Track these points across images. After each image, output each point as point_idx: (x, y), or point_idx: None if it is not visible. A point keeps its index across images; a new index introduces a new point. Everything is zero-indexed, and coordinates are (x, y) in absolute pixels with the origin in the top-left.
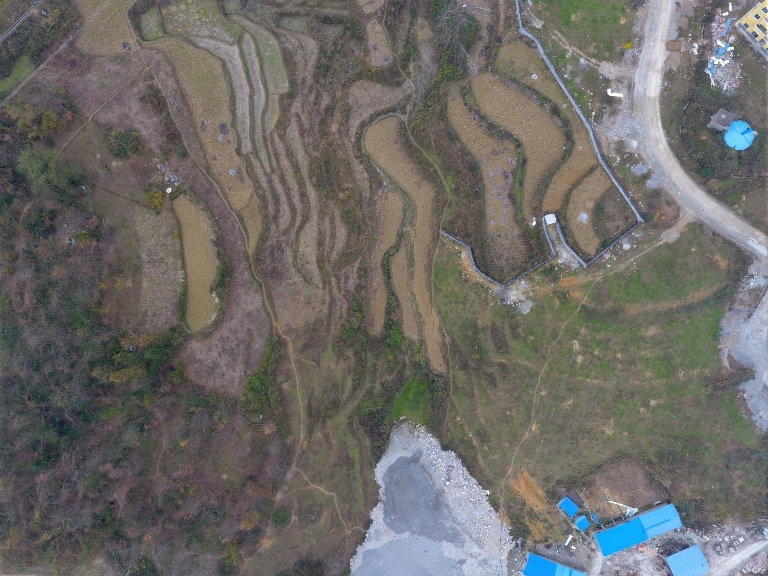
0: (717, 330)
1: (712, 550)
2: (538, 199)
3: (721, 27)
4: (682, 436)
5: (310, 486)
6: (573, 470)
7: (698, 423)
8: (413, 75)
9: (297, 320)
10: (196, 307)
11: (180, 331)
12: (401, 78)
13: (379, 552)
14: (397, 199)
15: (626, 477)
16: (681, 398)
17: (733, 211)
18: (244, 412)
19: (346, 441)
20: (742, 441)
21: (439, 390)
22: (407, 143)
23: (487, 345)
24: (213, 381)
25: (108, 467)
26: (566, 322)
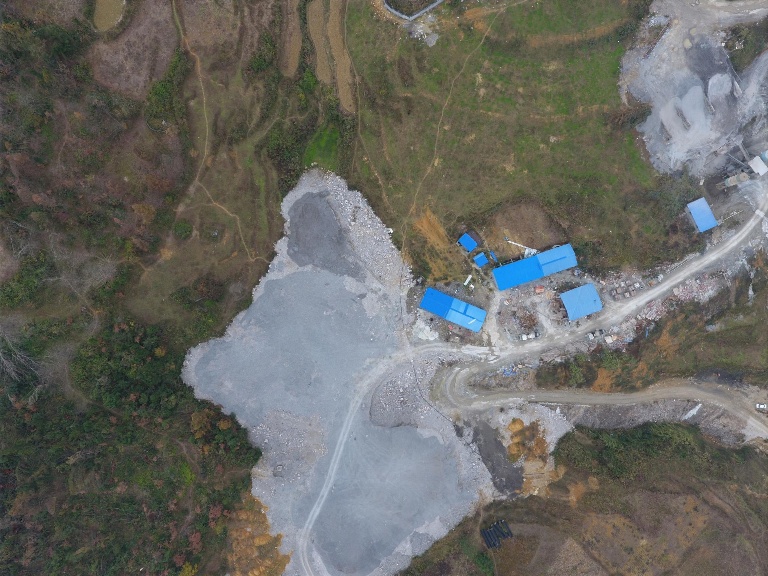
0: (617, 68)
1: (608, 296)
2: None
3: None
4: (581, 176)
5: (213, 204)
6: (473, 207)
7: (596, 162)
8: None
9: (206, 38)
10: (104, 8)
11: (86, 26)
12: None
13: (281, 282)
14: None
15: (526, 219)
16: (581, 136)
17: None
18: (148, 118)
19: (252, 169)
20: (639, 182)
21: (347, 129)
22: None
23: (394, 80)
24: (118, 83)
25: (1, 125)
26: (470, 54)
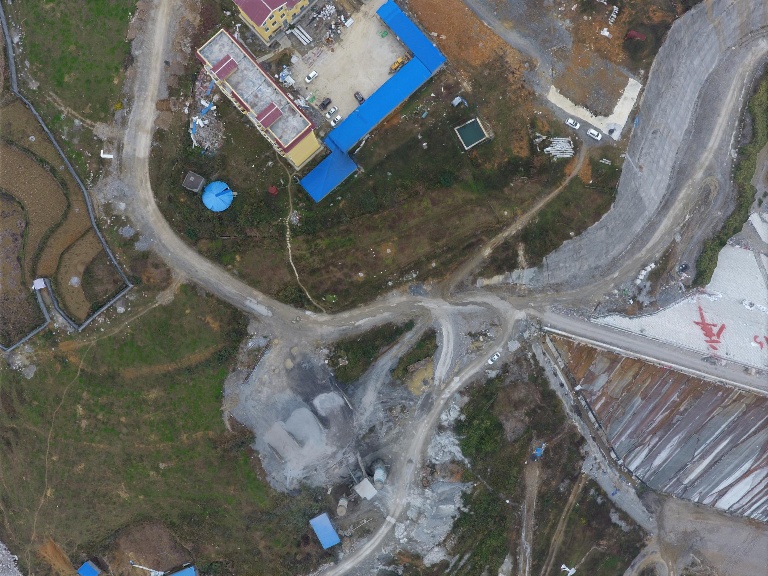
0: (220, 391)
1: None
2: (31, 263)
3: (204, 86)
4: (198, 498)
5: None
6: (91, 535)
7: (210, 485)
8: None
9: None
10: None
11: None
12: None
13: None
14: None
15: (151, 540)
16: (191, 460)
17: (228, 271)
18: None
19: None
20: (256, 502)
21: None
22: None
23: None
24: None
25: None
26: (68, 387)
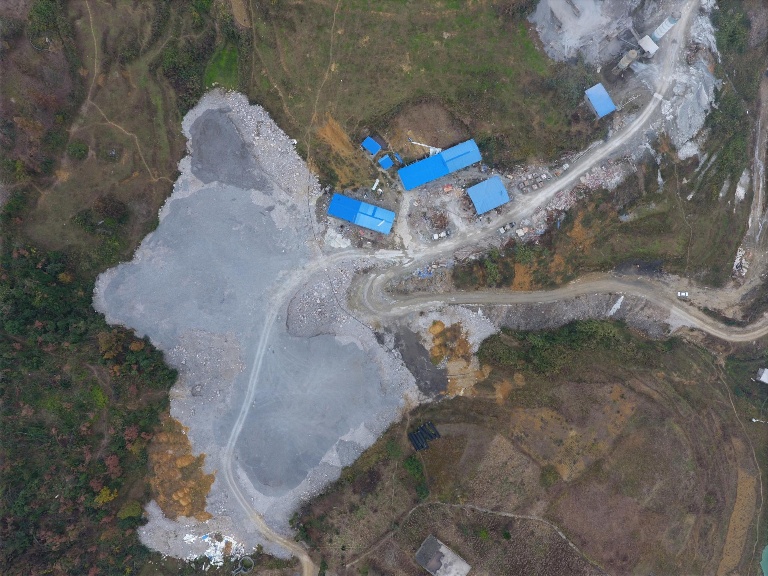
0: None
1: (517, 189)
2: None
3: None
4: (478, 71)
5: (108, 123)
6: (374, 109)
7: (491, 55)
8: None
9: None
10: None
11: None
12: None
13: (187, 201)
14: None
15: (428, 119)
16: (473, 31)
17: None
18: (31, 37)
19: (148, 87)
20: (535, 72)
21: (243, 43)
22: None
23: None
24: None
25: None
26: None
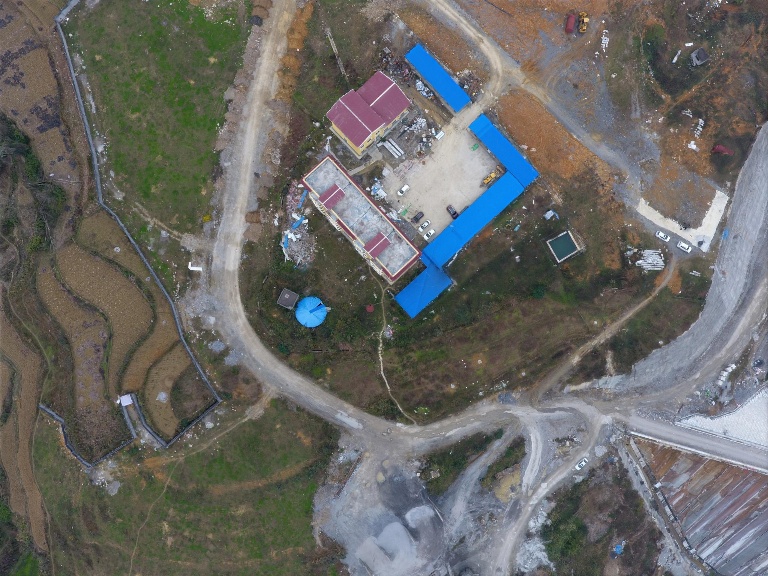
0: (310, 506)
1: None
2: (117, 378)
3: (296, 199)
4: None
5: None
6: None
7: None
8: (17, 240)
9: None
10: None
11: None
12: (3, 244)
13: None
14: (3, 368)
15: None
16: None
17: (319, 384)
18: None
19: None
20: None
21: None
22: (5, 313)
23: (80, 526)
24: None
25: None
26: (153, 503)
